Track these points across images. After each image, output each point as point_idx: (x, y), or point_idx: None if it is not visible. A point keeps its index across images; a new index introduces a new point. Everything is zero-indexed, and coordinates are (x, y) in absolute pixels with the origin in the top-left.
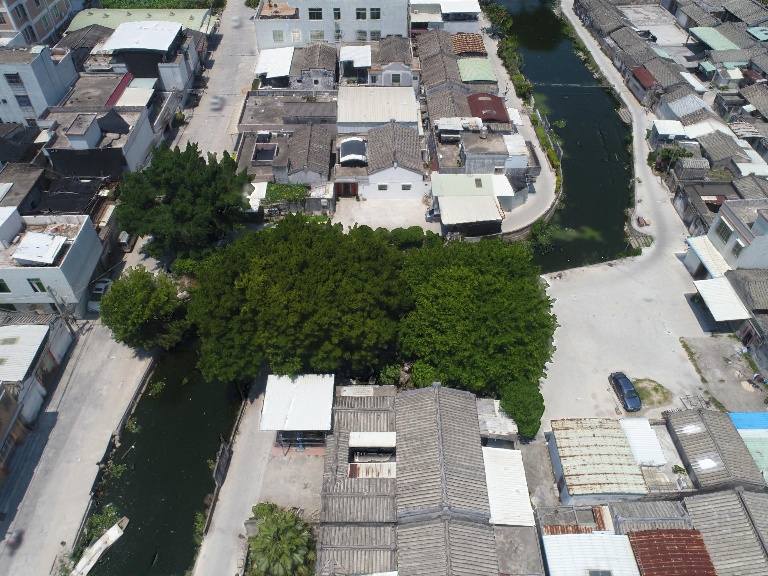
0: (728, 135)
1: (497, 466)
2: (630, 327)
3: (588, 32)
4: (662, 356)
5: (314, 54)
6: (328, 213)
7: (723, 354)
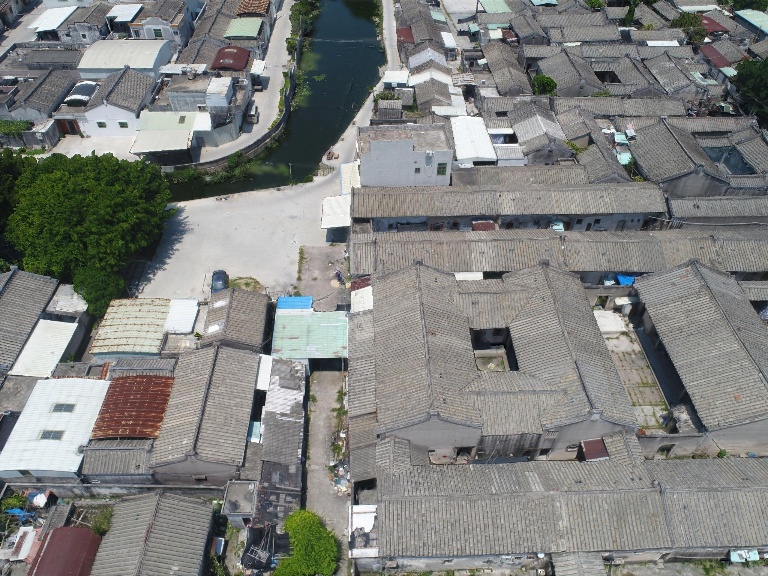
0: (443, 83)
1: (46, 334)
2: (262, 238)
3: (392, 0)
4: (275, 260)
5: (89, 11)
6: (47, 147)
7: (331, 259)
